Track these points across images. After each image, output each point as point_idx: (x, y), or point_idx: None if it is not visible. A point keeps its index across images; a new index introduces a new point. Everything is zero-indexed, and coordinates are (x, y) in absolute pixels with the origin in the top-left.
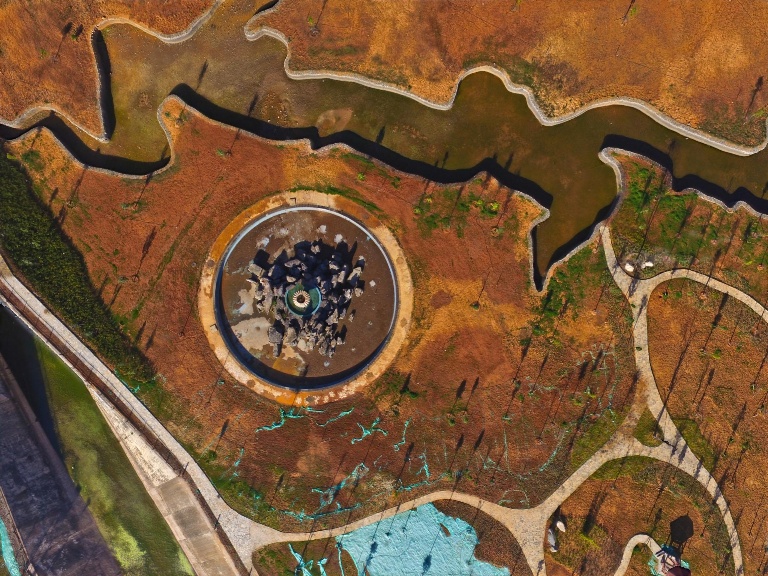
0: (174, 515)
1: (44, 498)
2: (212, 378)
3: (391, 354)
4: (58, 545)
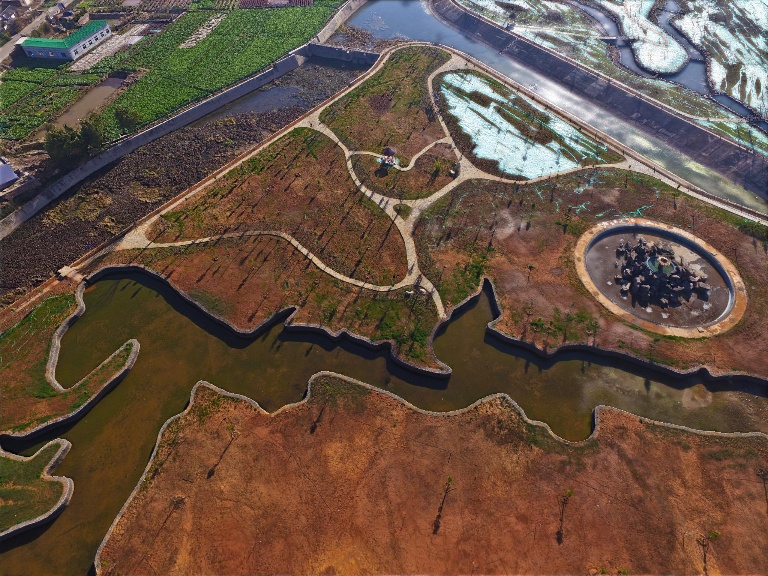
0: (679, 178)
1: (766, 181)
2: (698, 228)
3: (581, 243)
4: (741, 163)
